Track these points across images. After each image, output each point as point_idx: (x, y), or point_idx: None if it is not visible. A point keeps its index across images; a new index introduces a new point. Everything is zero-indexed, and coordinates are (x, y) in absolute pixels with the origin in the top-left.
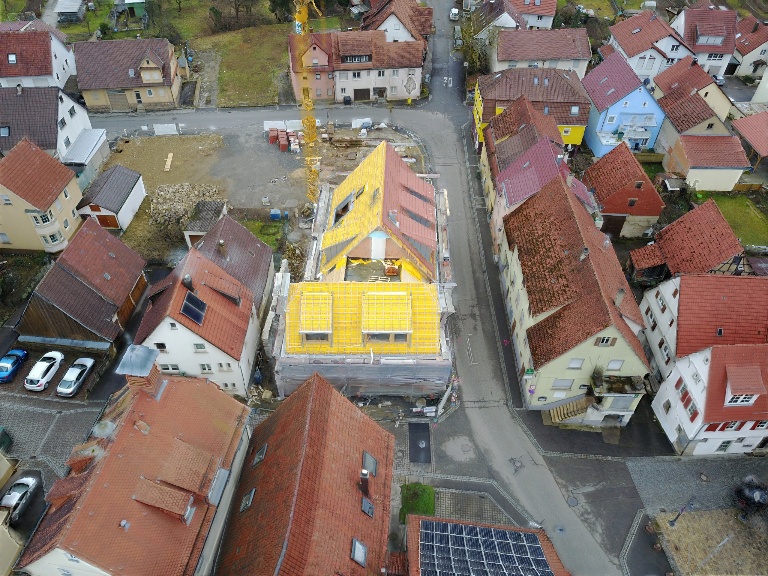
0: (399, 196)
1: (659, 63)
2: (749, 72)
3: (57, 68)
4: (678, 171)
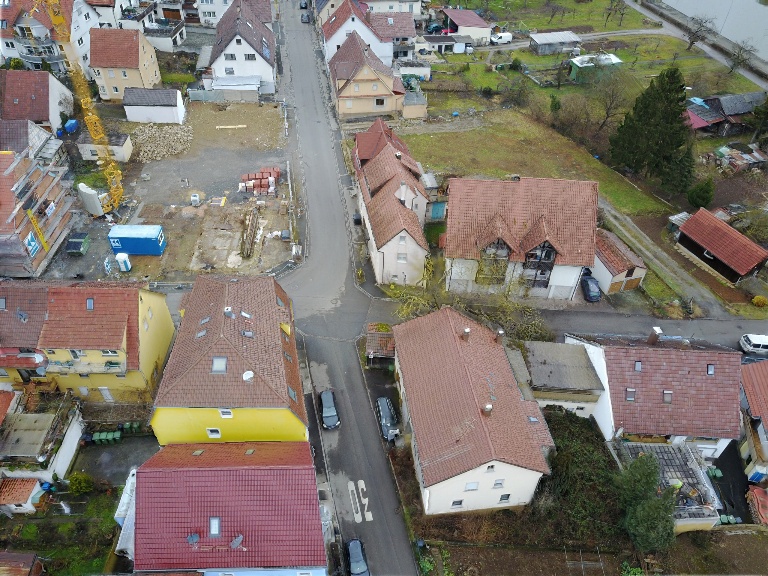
0: None
1: None
2: None
3: None
4: None
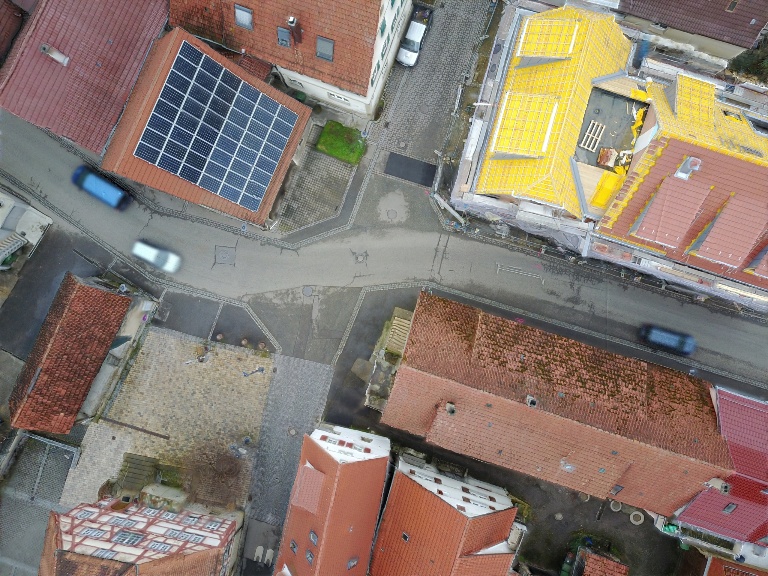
0: (754, 200)
1: None
2: None
3: None
4: None
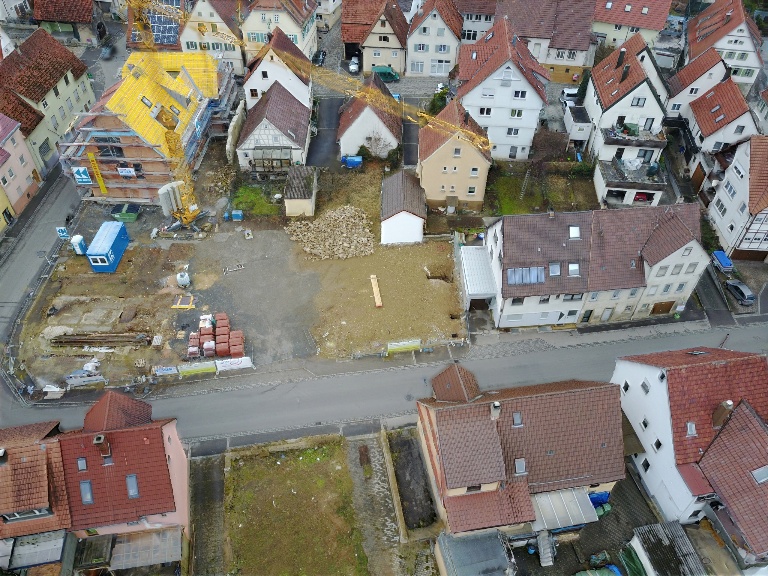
0: None
1: None
2: None
3: (634, 389)
4: None
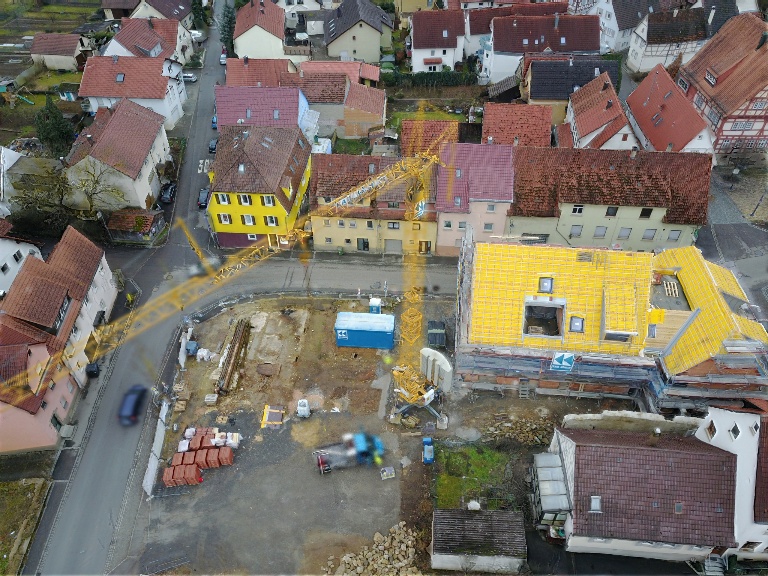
0: None
1: (176, 89)
2: (183, 60)
3: None
4: (368, 128)
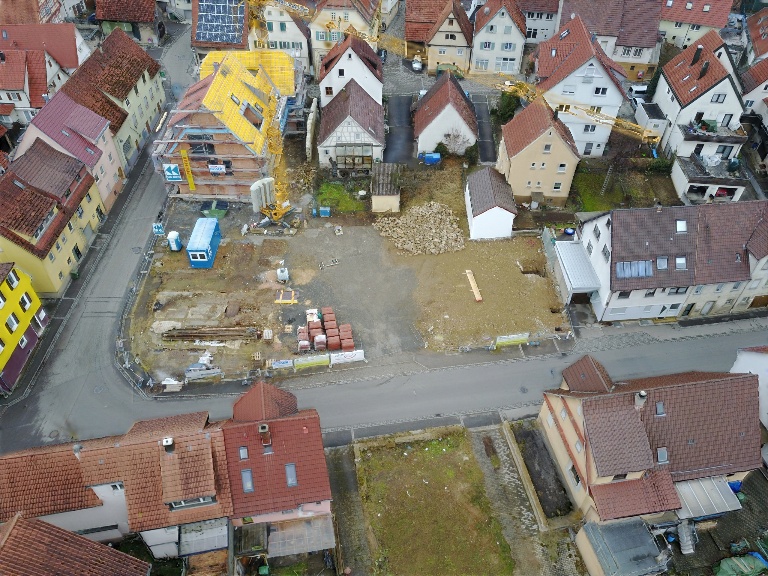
0: None
1: None
2: None
3: (761, 379)
4: None
